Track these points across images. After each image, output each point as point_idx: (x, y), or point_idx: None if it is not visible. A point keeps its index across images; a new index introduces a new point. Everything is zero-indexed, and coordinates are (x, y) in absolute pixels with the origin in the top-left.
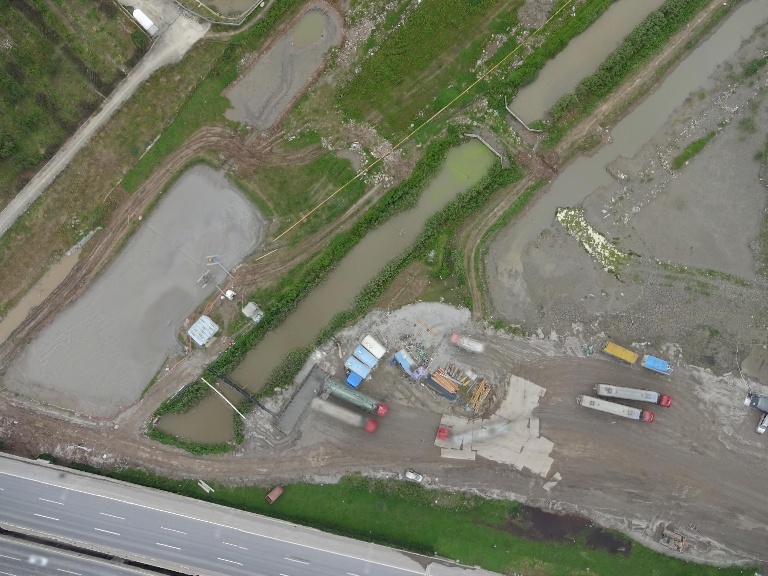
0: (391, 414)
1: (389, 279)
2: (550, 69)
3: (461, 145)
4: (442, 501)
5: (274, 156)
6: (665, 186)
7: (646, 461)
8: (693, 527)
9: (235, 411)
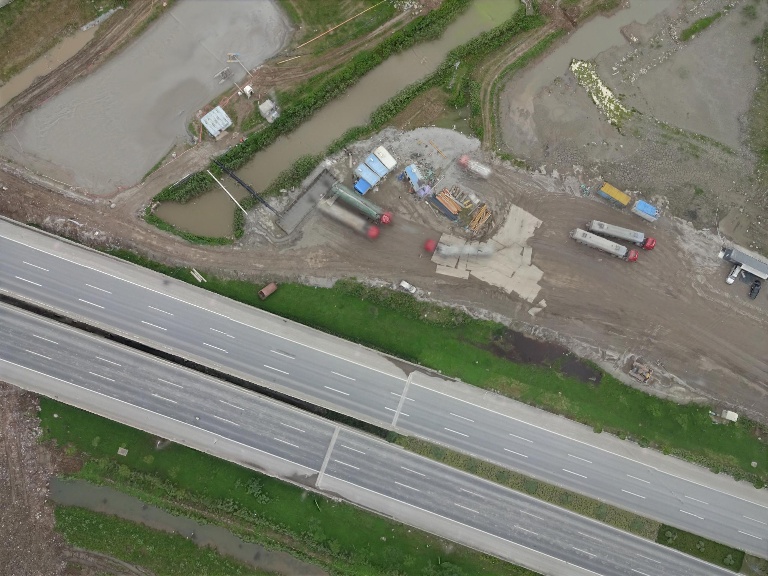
0: (393, 227)
1: (407, 100)
2: None
3: None
4: (431, 316)
5: None
6: (671, 54)
7: (625, 298)
8: (660, 363)
9: (238, 206)
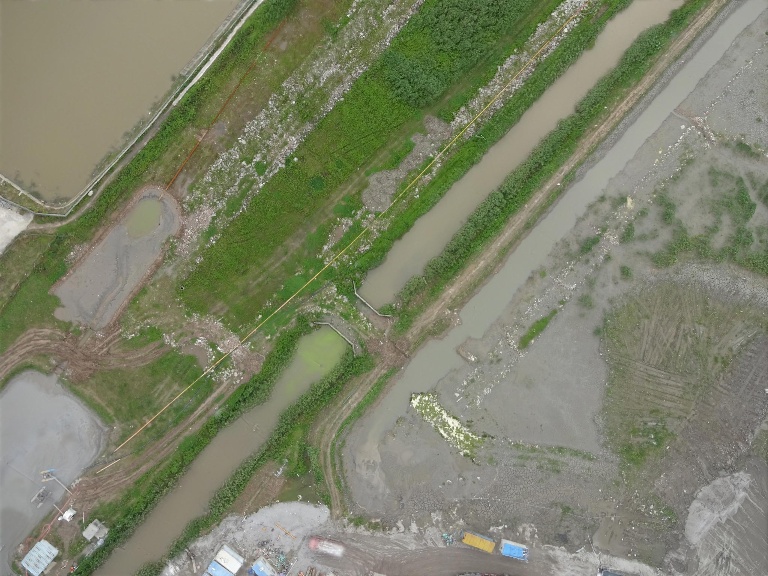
0: None
1: (243, 482)
2: (398, 250)
3: (312, 333)
4: None
5: (112, 357)
6: (513, 365)
7: None
8: None
9: None
